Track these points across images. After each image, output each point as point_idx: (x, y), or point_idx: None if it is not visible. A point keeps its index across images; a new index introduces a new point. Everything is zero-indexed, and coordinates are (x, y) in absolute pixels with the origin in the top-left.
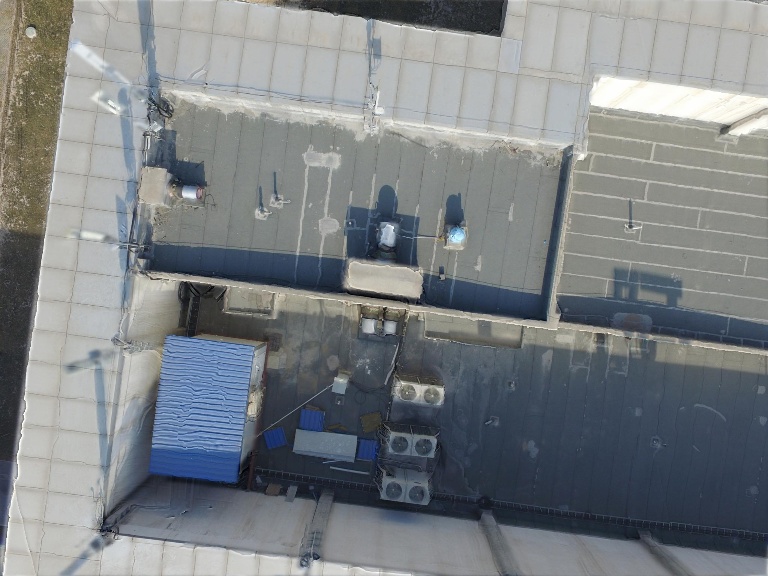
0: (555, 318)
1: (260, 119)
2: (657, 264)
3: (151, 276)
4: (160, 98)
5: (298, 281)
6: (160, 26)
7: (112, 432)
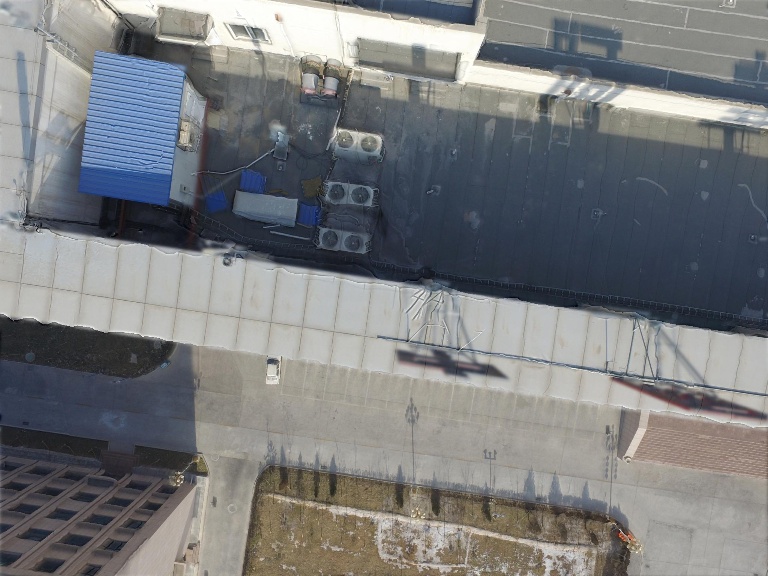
0: (483, 23)
1: None
2: (598, 15)
3: None
4: None
5: None
6: None
7: (35, 126)
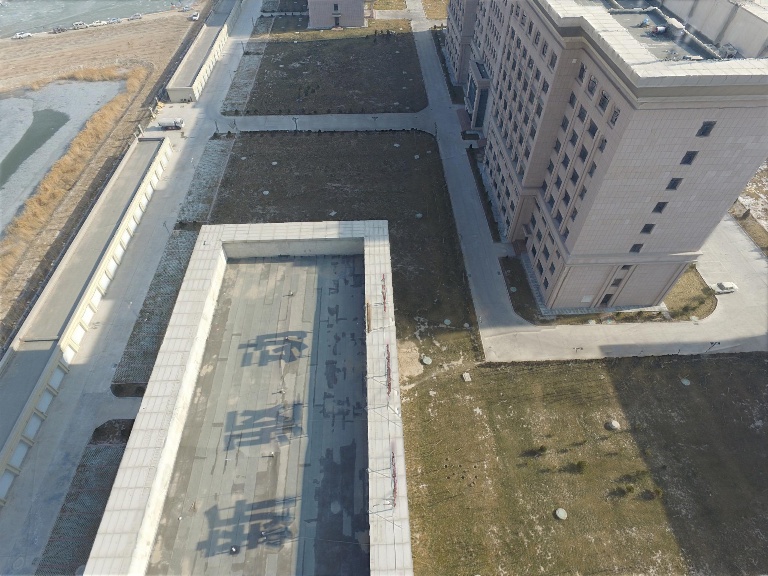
0: None
1: None
2: None
3: None
4: None
5: (690, 47)
6: (639, 62)
7: None
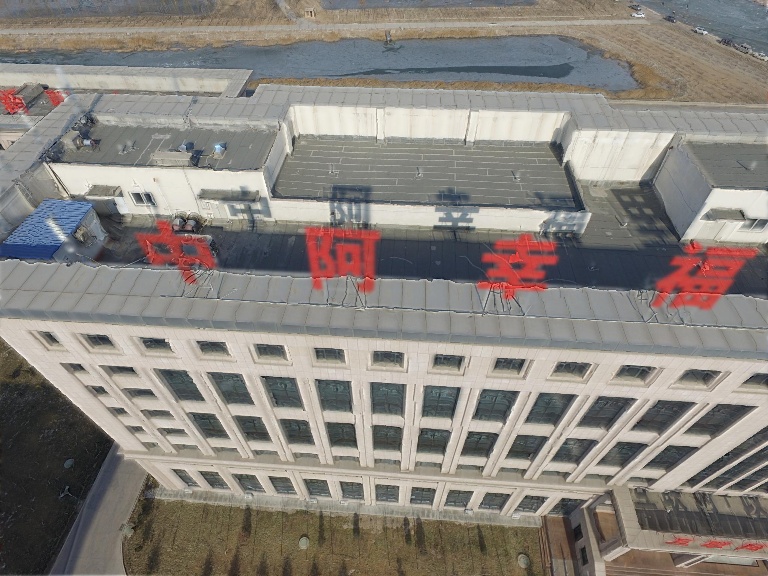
0: None
1: (136, 127)
2: (347, 184)
3: (50, 165)
4: (89, 114)
5: None
6: (102, 100)
7: None
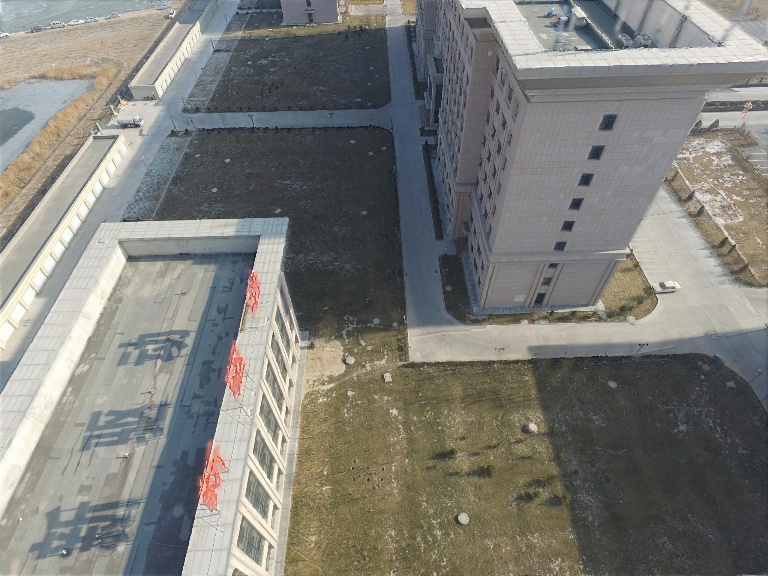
0: None
1: None
2: None
3: None
4: None
5: None
6: (523, 53)
7: None
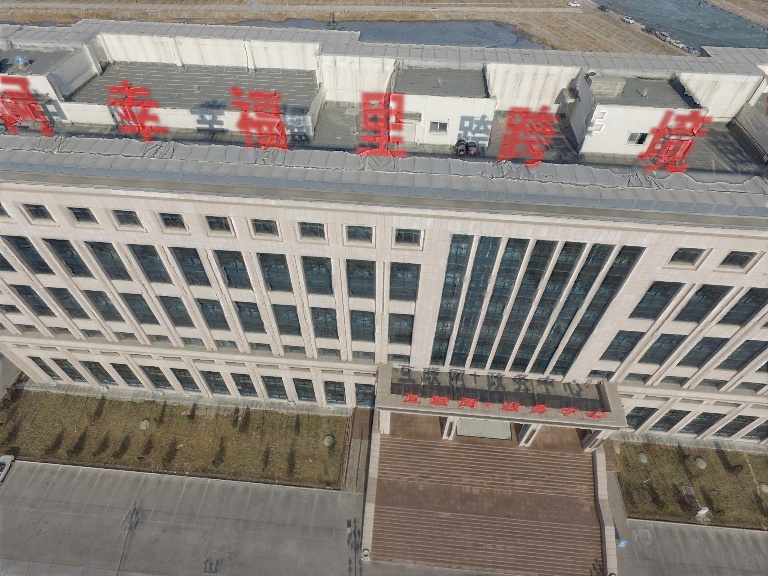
0: None
1: None
2: (136, 96)
3: None
4: None
5: None
6: None
7: None
